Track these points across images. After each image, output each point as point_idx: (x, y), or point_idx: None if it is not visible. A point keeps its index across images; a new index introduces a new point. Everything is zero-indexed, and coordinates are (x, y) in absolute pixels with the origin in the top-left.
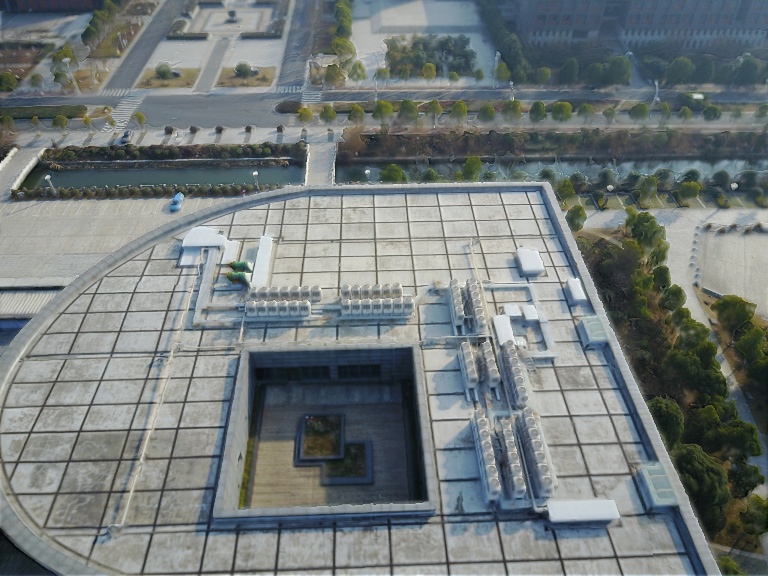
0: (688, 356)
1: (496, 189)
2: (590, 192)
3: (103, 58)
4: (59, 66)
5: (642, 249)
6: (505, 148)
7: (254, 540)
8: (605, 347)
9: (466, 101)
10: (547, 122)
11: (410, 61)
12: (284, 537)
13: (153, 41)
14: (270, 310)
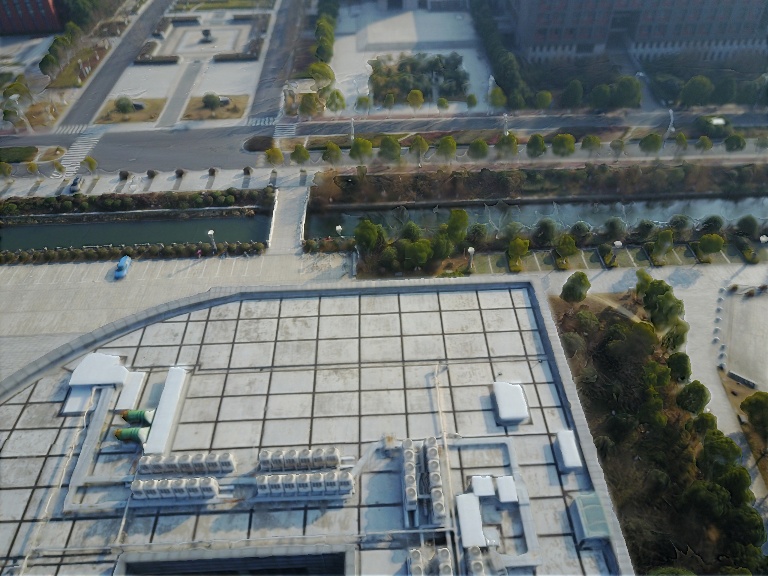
0: (715, 491)
1: (472, 286)
2: (595, 245)
3: (63, 89)
4: (9, 102)
5: (656, 325)
6: (499, 189)
7: None
8: (606, 547)
9: (456, 132)
10: (547, 157)
11: (396, 85)
12: None
13: (119, 67)
14: (162, 492)
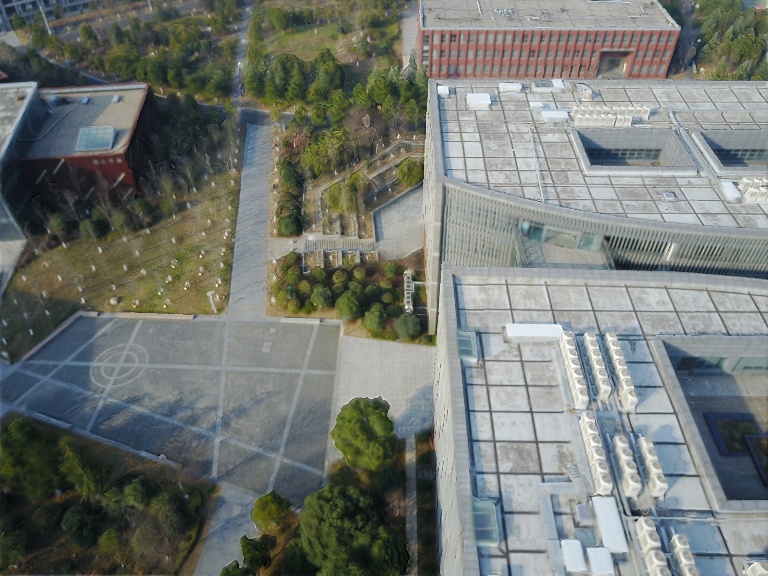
0: None
1: None
2: None
3: None
4: None
5: None
6: None
7: None
8: None
9: None
10: None
11: None
12: (767, 331)
13: None
14: None
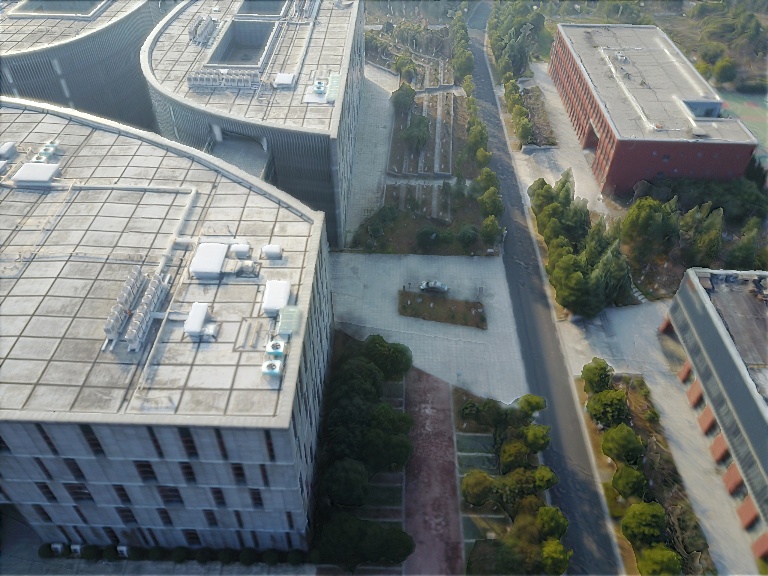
0: None
1: None
2: None
3: None
4: None
5: None
6: None
7: (105, 14)
8: None
9: None
10: None
11: None
12: None
13: None
14: None
